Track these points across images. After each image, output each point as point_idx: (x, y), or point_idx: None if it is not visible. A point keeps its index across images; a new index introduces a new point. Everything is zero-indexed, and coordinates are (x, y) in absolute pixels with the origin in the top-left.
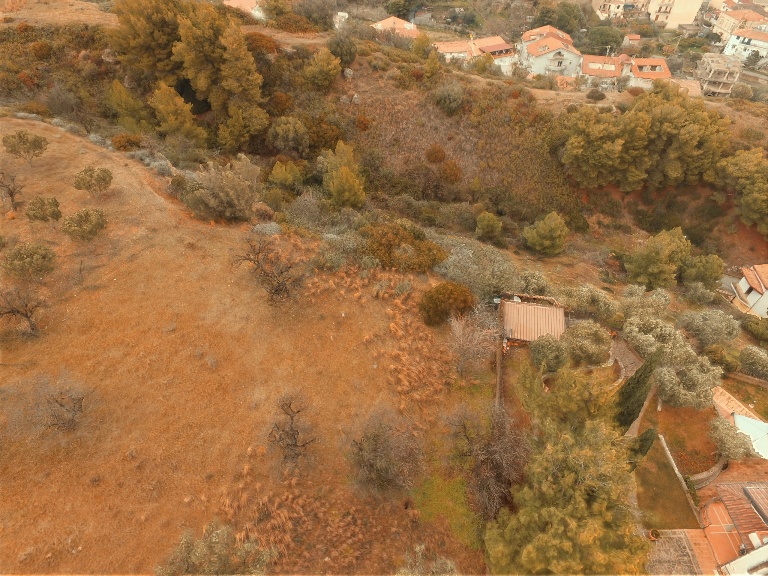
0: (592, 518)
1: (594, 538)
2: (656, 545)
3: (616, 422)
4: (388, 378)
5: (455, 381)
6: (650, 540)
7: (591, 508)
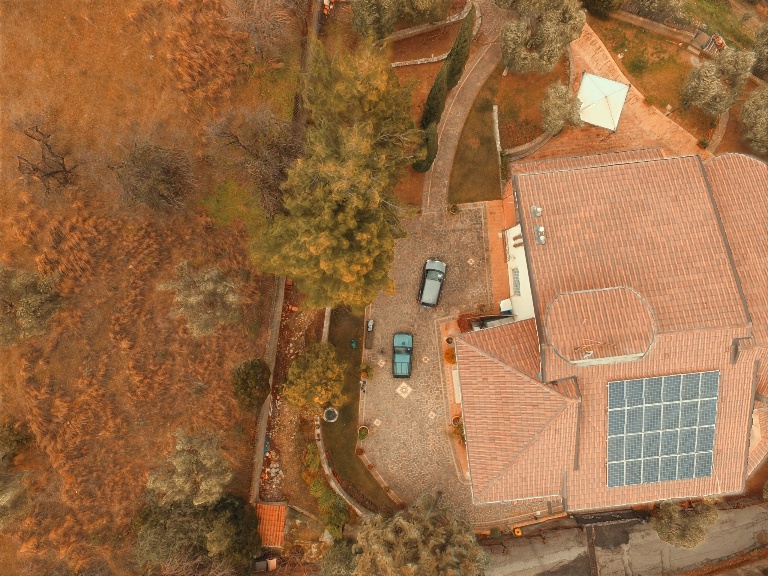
0: (336, 227)
1: (325, 248)
2: (455, 217)
3: (427, 105)
4: (168, 72)
5: (250, 68)
6: (450, 213)
7: (337, 218)
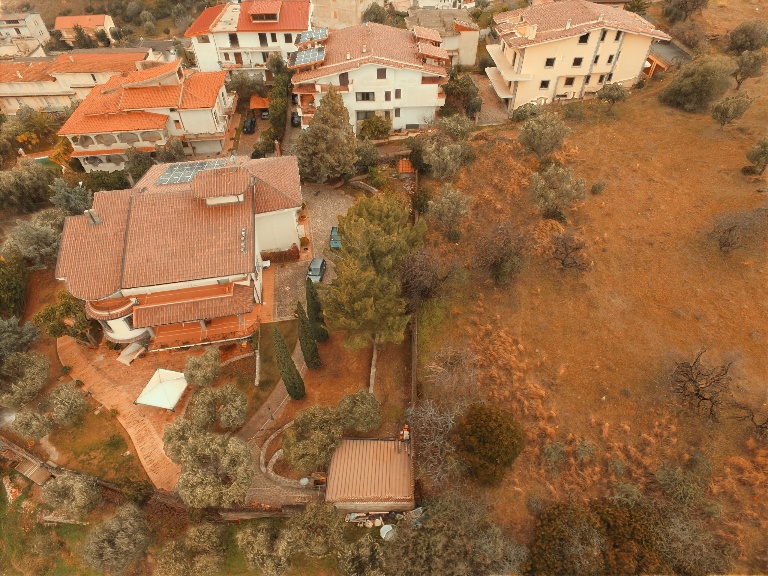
0: (371, 221)
1: None
2: None
3: None
4: None
5: None
6: None
7: None
